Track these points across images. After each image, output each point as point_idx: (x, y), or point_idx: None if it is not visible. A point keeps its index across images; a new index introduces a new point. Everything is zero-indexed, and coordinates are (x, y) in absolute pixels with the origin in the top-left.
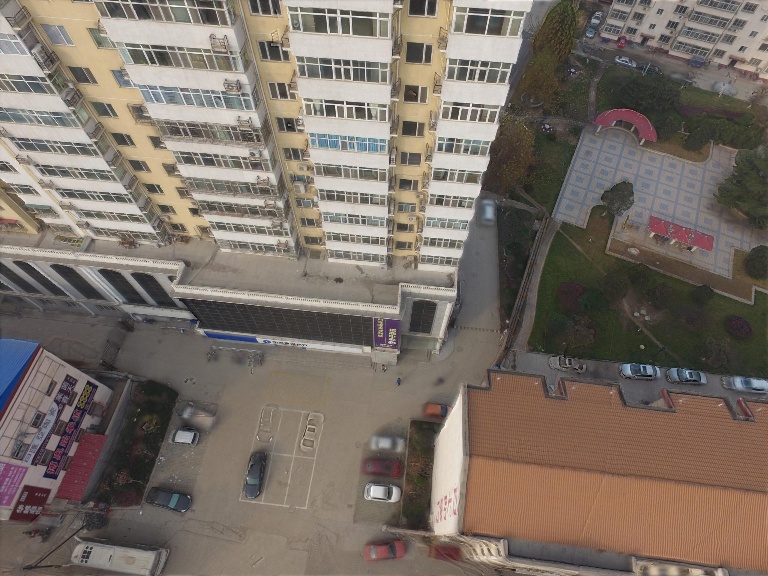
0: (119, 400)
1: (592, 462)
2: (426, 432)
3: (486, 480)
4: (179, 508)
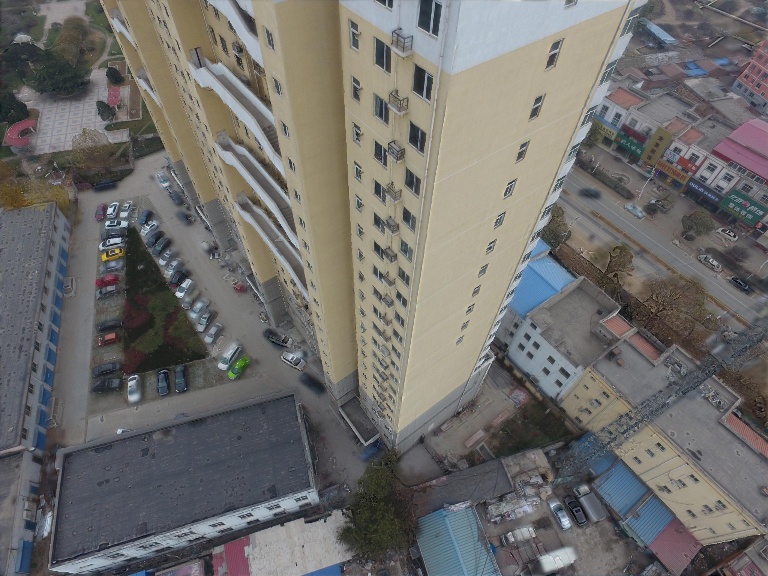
0: None
1: None
2: None
3: None
4: None
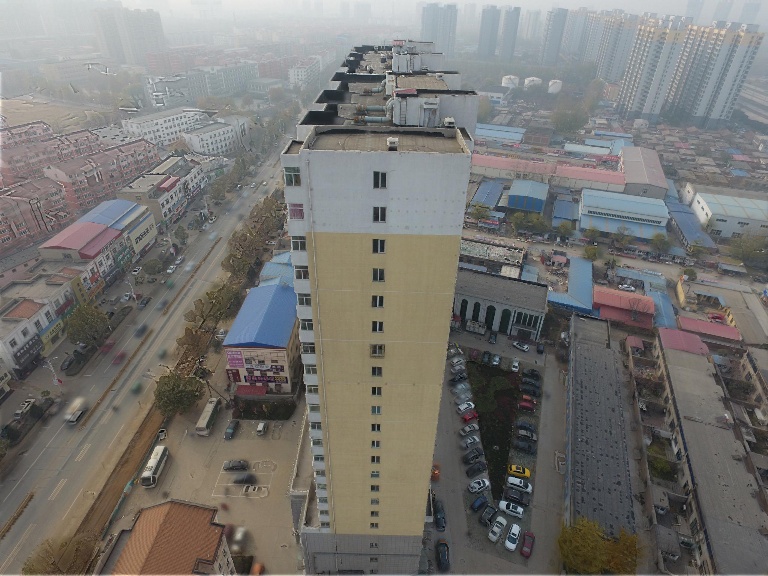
0: (283, 395)
1: (147, 572)
2: (242, 566)
3: None
4: (226, 434)
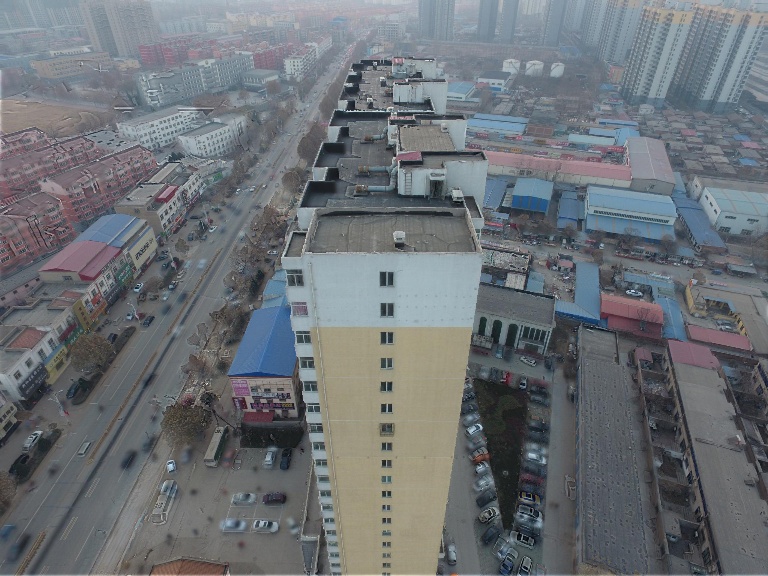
0: (290, 421)
1: None
2: None
3: (170, 572)
4: (234, 465)
